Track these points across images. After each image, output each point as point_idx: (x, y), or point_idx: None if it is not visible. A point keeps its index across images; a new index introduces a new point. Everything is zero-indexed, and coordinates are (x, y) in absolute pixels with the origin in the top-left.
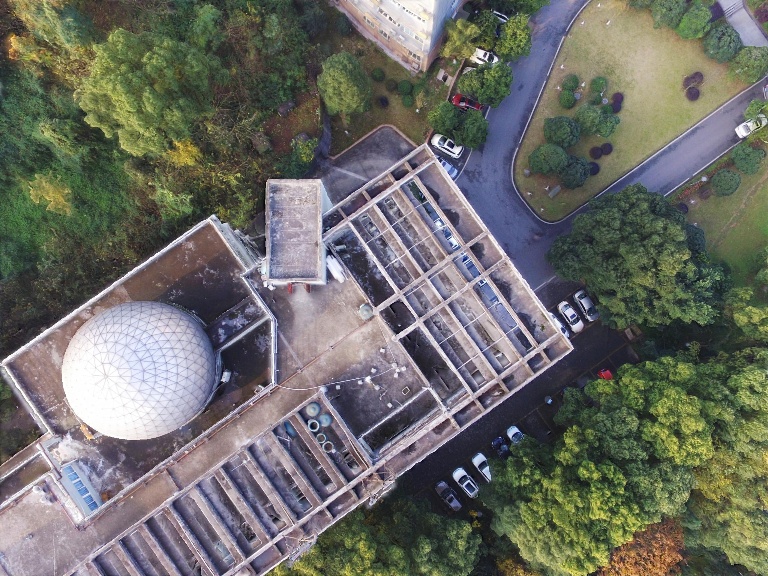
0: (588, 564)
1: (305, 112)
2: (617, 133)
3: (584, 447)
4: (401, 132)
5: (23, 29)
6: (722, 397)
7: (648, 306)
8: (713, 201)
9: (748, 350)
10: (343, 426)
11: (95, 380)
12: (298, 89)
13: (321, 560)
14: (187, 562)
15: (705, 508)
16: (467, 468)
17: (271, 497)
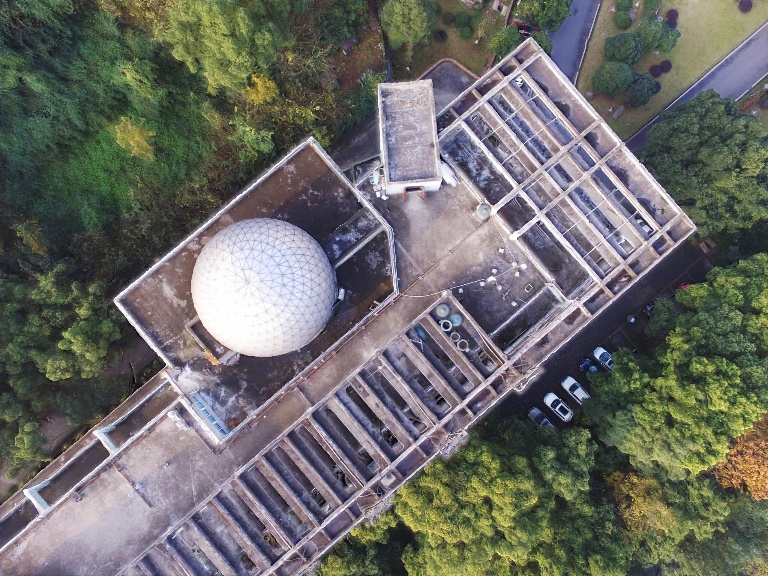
0: (710, 456)
1: (369, 49)
2: (674, 50)
3: (692, 344)
4: (462, 65)
5: None
6: None
7: (728, 212)
8: None
9: None
10: (475, 323)
11: (237, 287)
12: (360, 26)
13: (446, 474)
14: (331, 472)
15: None
16: (557, 392)
17: (409, 400)
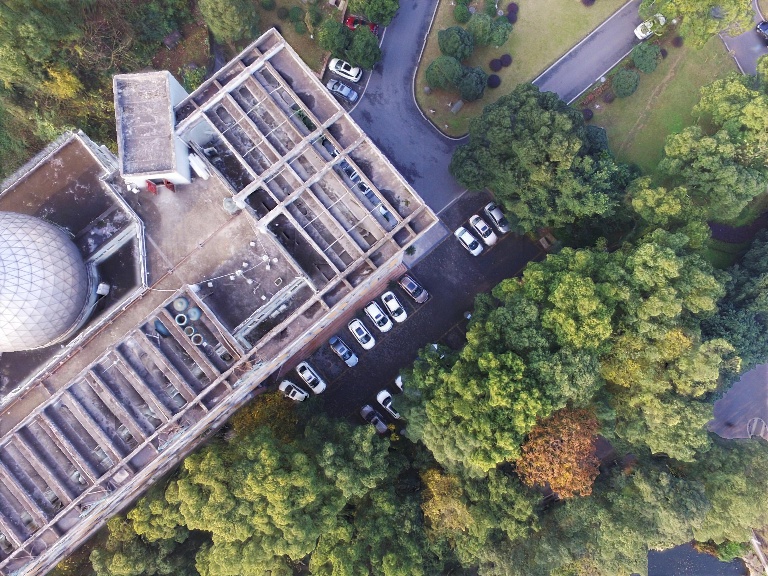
0: (493, 453)
1: (194, 44)
2: (516, 44)
3: (484, 339)
4: None
5: None
6: (618, 277)
7: (552, 206)
8: (618, 104)
9: (648, 235)
10: (211, 317)
11: None
12: (185, 21)
13: (221, 472)
14: (64, 469)
15: (622, 399)
16: (391, 390)
17: (144, 396)
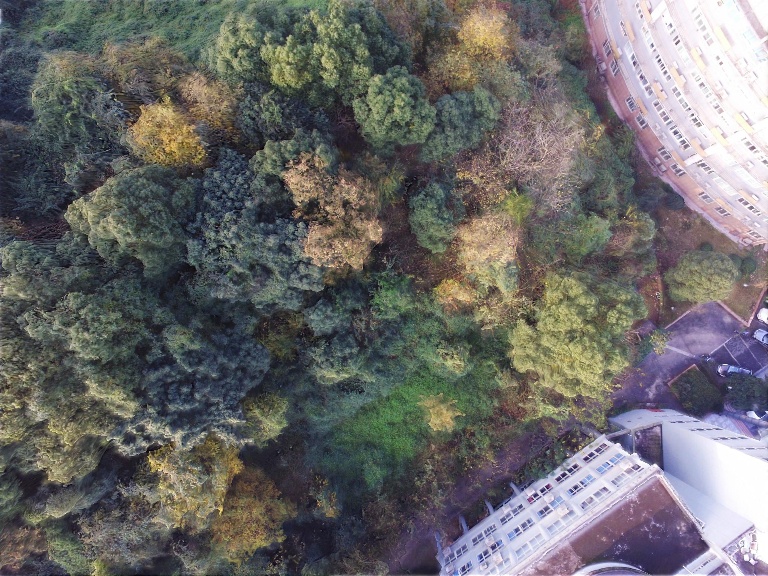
0: None
1: (645, 296)
2: None
3: None
4: (726, 306)
5: (452, 270)
6: None
7: None
8: None
9: None
10: None
11: None
12: None
13: None
14: None
15: None
16: None
17: None
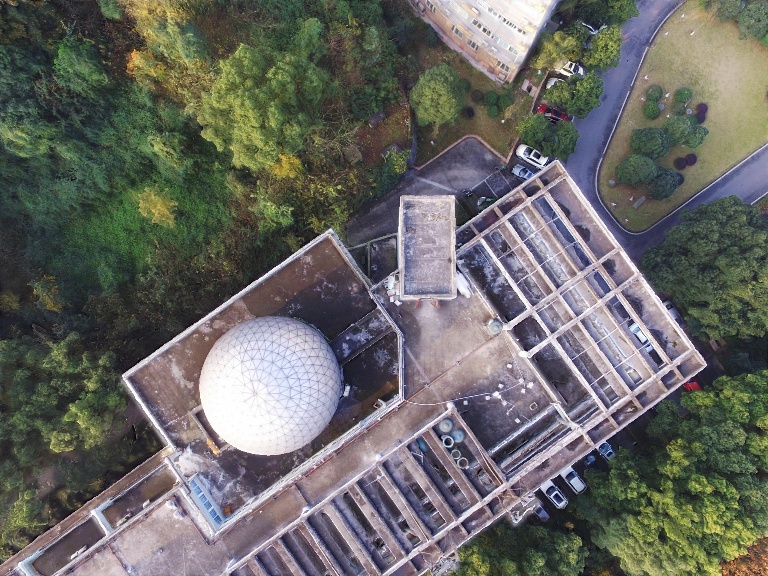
0: None
1: (395, 123)
2: (701, 144)
3: (693, 461)
4: (486, 143)
5: (140, 43)
6: None
7: (741, 318)
8: None
9: None
10: (477, 442)
11: (244, 397)
12: (388, 100)
13: None
14: None
15: None
16: (553, 479)
17: (405, 513)
